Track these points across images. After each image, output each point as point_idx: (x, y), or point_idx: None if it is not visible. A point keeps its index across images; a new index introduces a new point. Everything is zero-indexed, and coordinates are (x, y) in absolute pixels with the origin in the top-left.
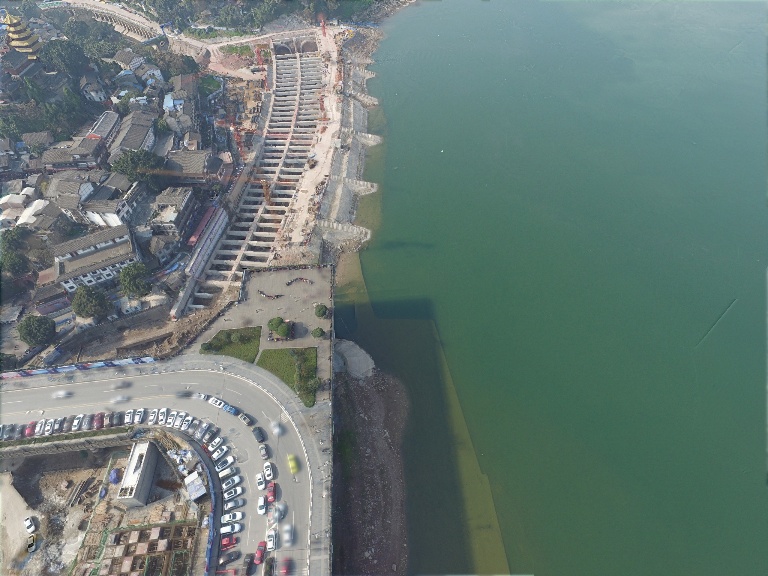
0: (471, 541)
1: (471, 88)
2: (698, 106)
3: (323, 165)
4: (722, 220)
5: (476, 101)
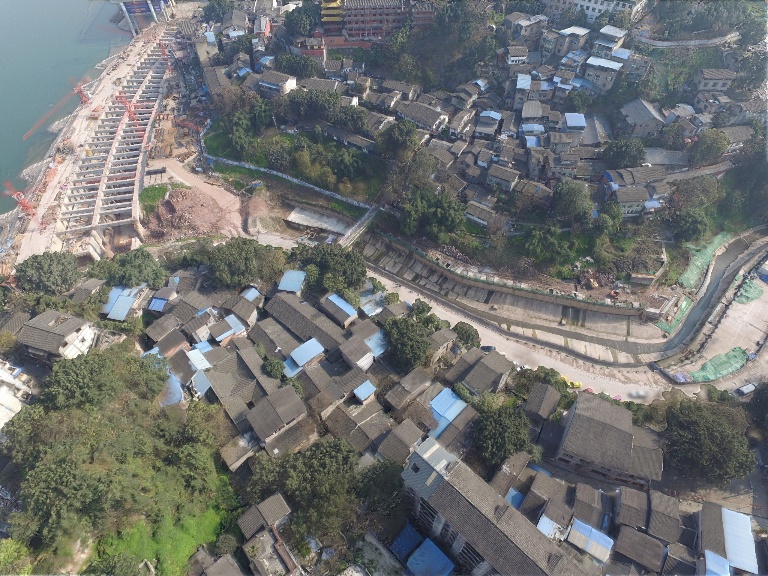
0: (102, 1)
1: None
2: None
3: (109, 81)
4: None
5: None
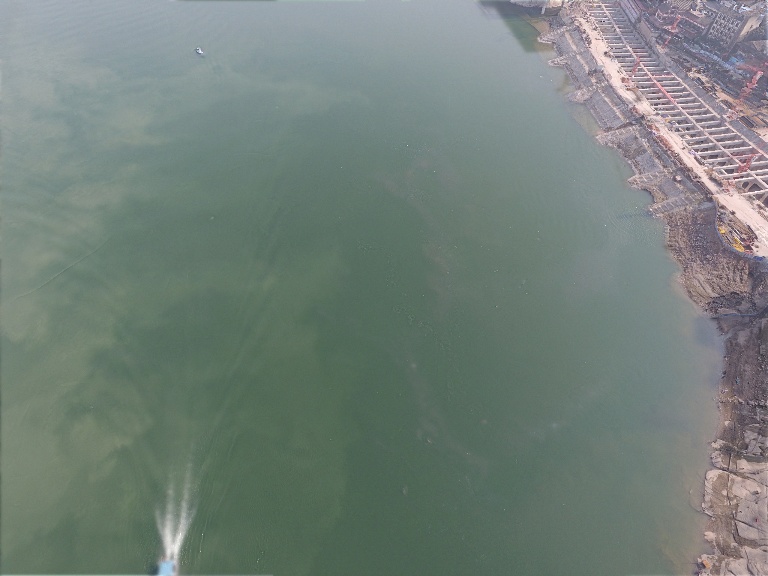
0: None
1: (492, 161)
2: (235, 151)
3: (599, 54)
4: (309, 51)
5: (483, 142)
